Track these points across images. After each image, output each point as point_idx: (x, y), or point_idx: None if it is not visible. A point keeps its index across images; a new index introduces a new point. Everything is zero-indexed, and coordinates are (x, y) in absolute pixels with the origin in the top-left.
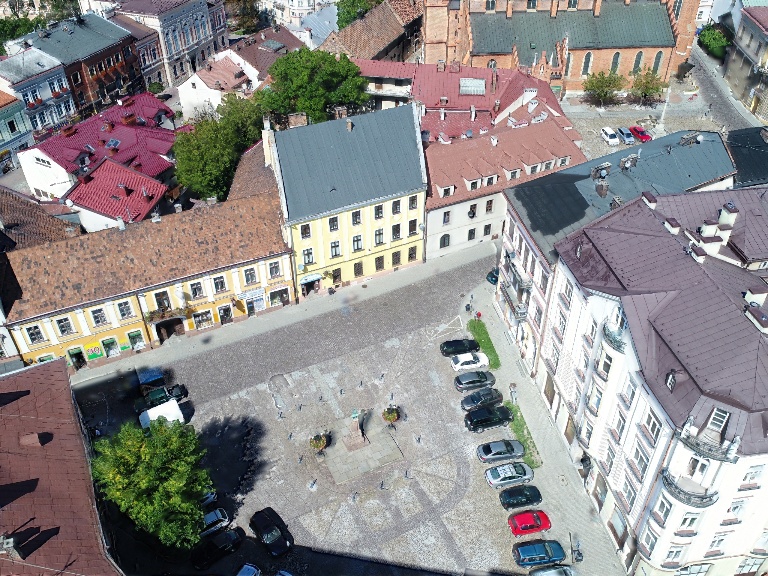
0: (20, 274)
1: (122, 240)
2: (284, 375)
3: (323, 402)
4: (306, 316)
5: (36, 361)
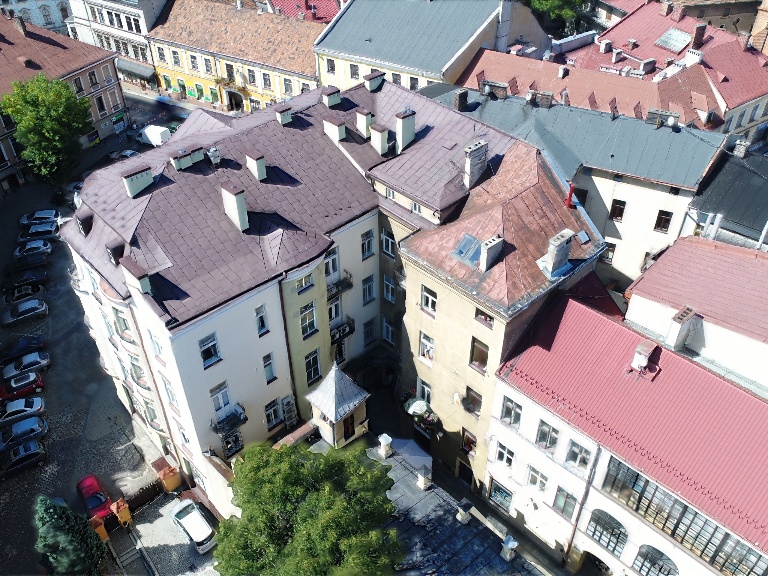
0: (174, 10)
1: (233, 16)
2: None
3: None
4: None
5: (162, 76)
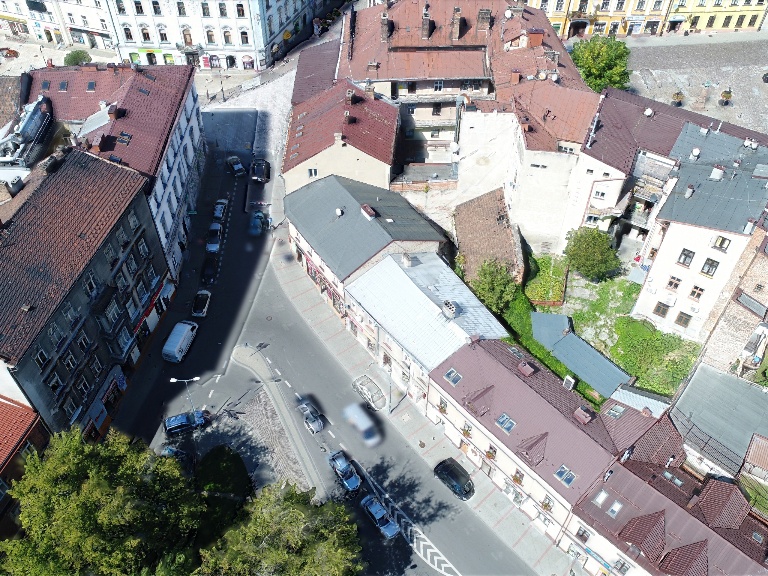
0: None
1: None
2: (650, 70)
3: (676, 87)
4: (667, 44)
5: None
